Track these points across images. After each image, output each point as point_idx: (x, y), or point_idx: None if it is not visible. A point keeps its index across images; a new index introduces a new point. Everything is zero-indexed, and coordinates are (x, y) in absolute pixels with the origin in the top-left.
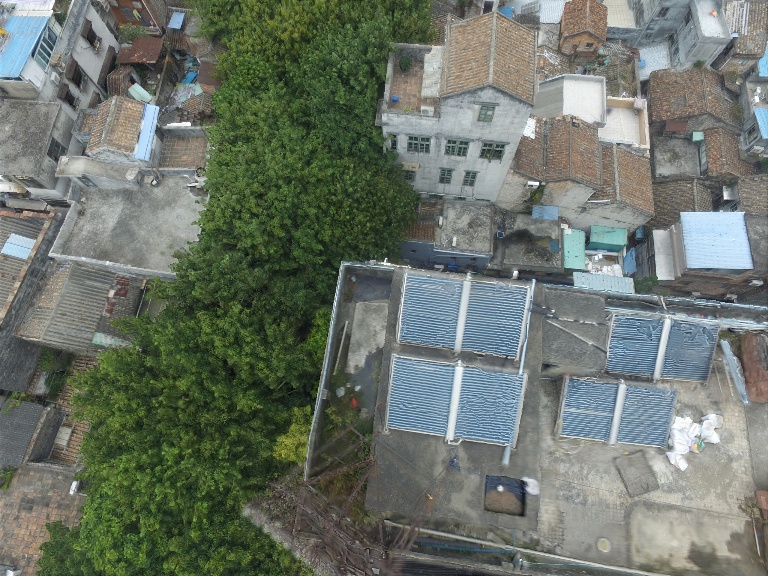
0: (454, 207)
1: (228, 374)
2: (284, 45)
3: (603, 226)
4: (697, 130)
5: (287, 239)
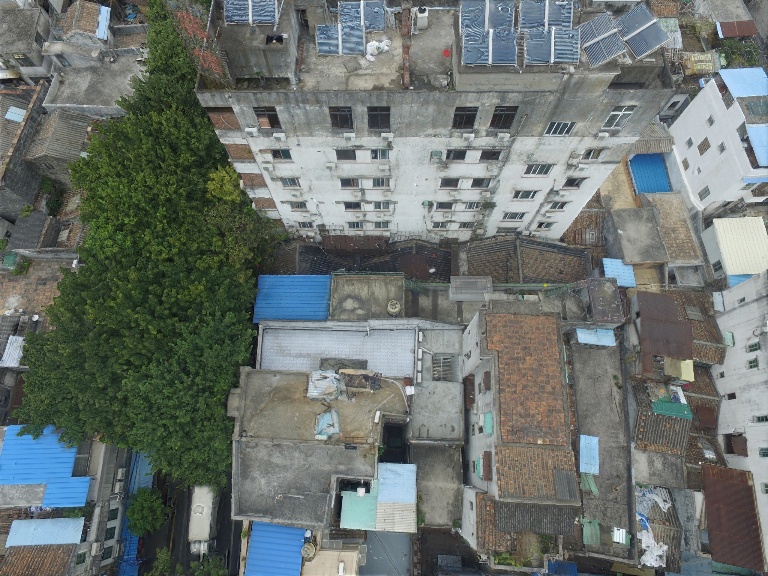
0: None
1: None
2: None
3: None
4: None
5: None
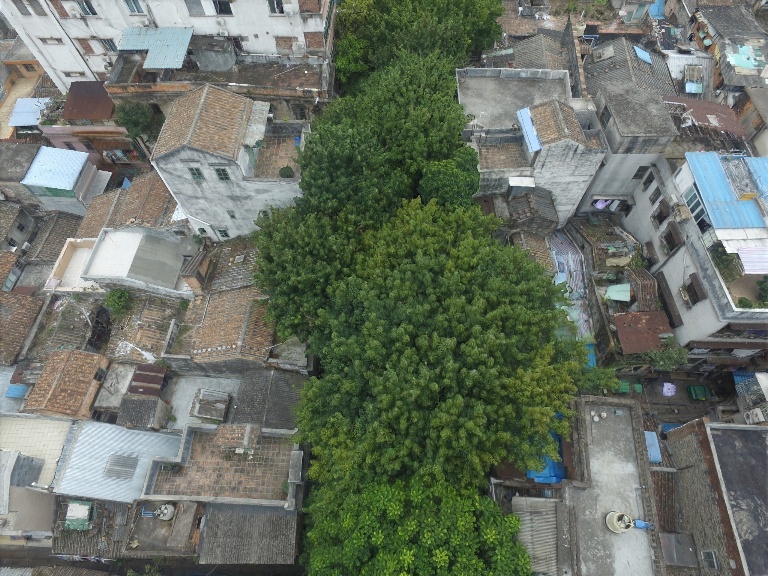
0: None
1: None
2: None
3: None
4: None
5: None
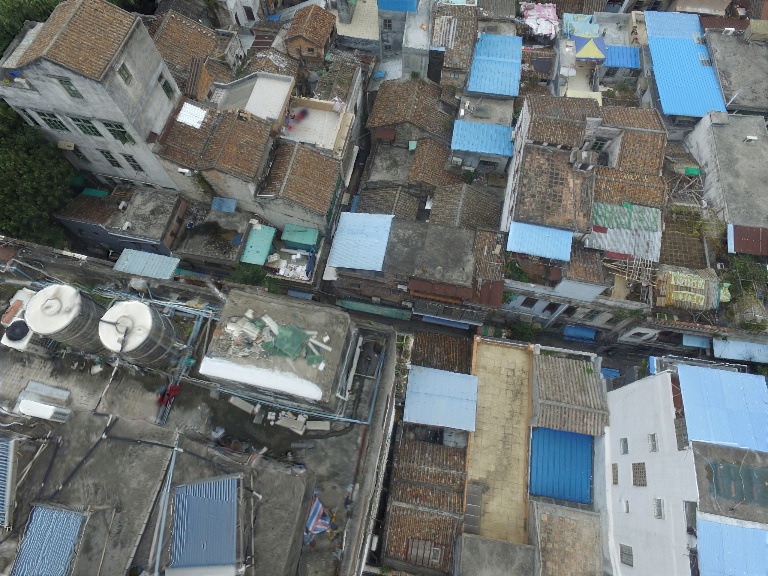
0: (143, 194)
1: None
2: None
3: (296, 225)
4: (412, 139)
5: None
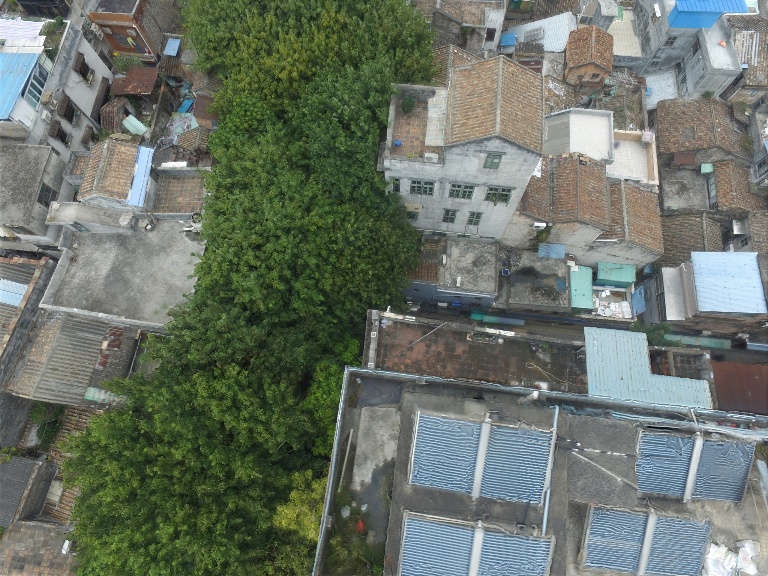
0: (458, 244)
1: (226, 435)
2: (282, 83)
3: (611, 262)
4: (706, 162)
5: (286, 289)
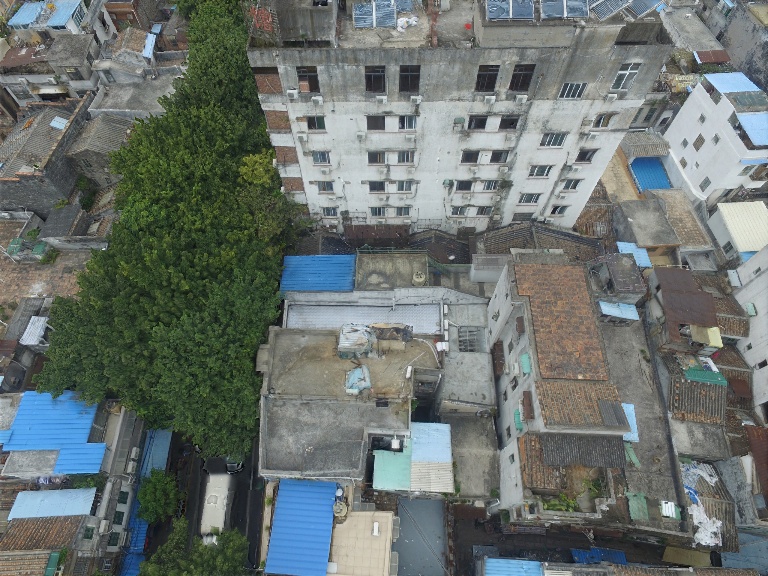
0: None
1: None
2: (232, 4)
3: None
4: None
5: (240, 89)
